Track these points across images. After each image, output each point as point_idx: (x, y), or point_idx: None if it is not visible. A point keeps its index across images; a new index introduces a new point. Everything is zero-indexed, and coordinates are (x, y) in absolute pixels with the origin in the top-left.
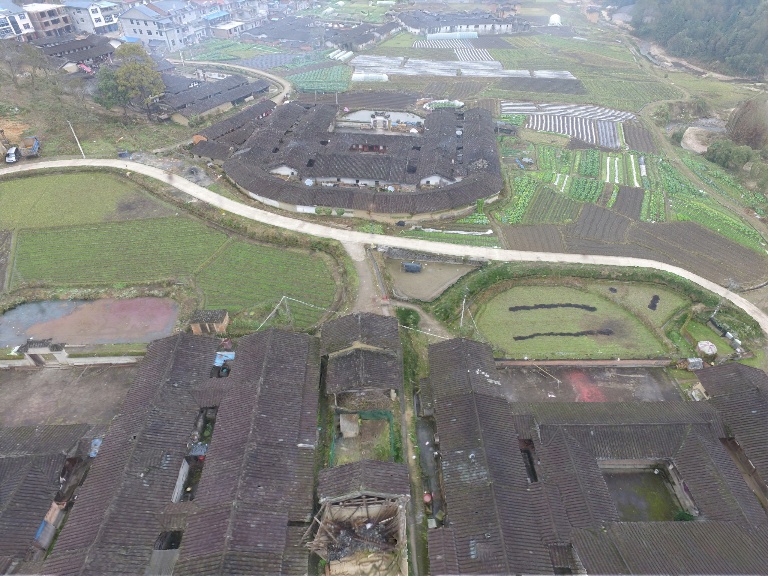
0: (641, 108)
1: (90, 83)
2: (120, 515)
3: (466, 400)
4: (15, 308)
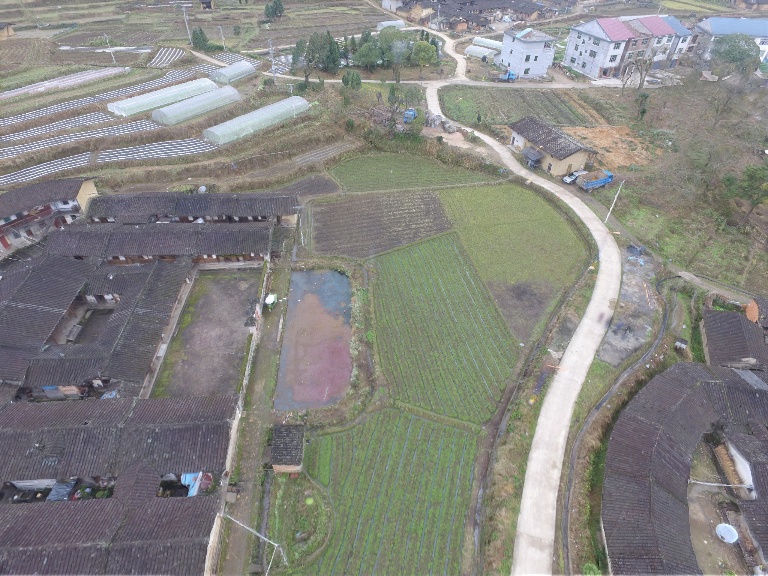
0: None
1: (744, 160)
2: (2, 441)
3: None
4: (342, 275)
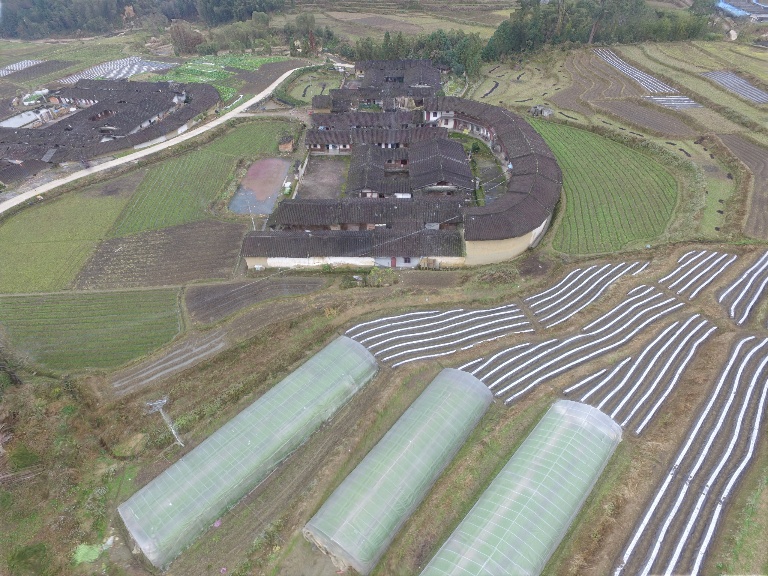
0: (127, 54)
1: None
2: None
3: (361, 90)
4: None
